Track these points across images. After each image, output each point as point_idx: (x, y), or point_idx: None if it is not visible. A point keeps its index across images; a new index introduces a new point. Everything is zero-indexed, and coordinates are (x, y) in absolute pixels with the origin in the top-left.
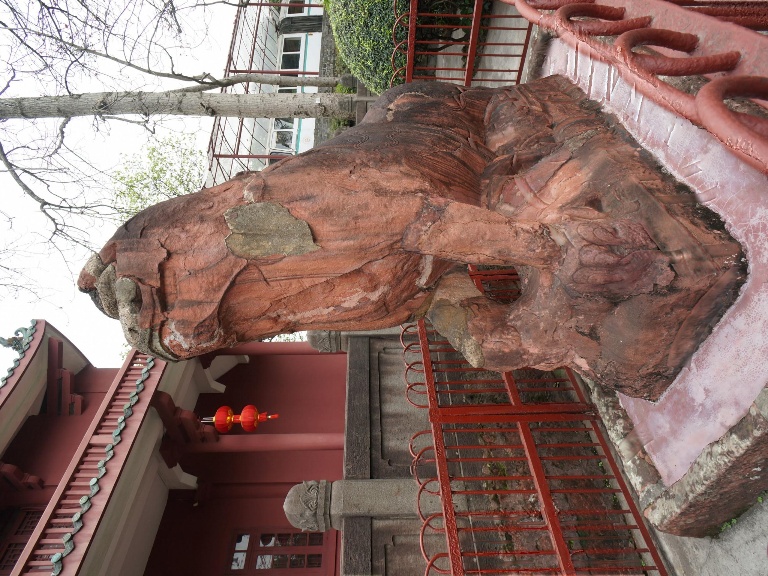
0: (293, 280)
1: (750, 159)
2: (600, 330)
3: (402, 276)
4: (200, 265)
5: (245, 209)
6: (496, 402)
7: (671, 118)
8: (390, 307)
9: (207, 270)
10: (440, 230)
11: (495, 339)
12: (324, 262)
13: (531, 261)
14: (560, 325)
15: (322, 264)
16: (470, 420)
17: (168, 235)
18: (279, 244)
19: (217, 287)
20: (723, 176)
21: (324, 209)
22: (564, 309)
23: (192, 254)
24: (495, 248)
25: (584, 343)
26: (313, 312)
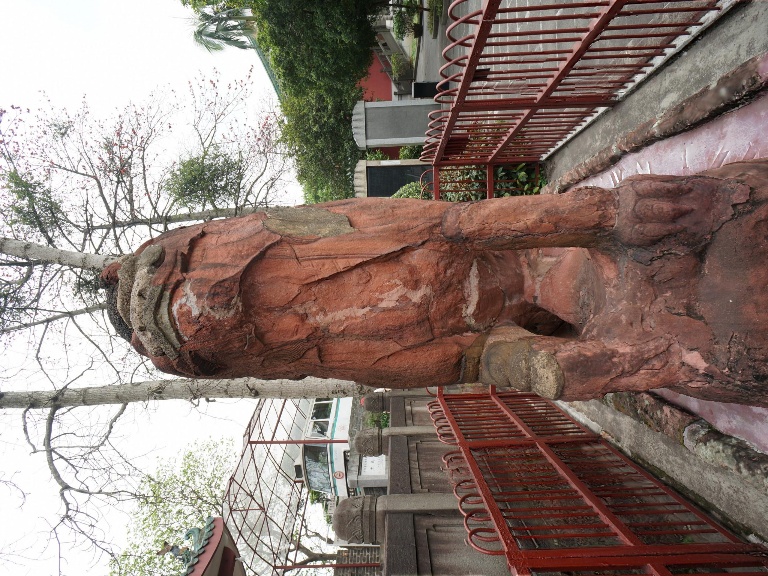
0: (326, 260)
1: (766, 101)
2: (699, 308)
3: (446, 284)
4: (232, 240)
5: (286, 210)
6: (605, 544)
7: (680, 149)
8: (435, 330)
9: (239, 241)
10: (479, 207)
11: (570, 346)
12: (360, 243)
13: (583, 211)
14: (646, 311)
15: (358, 244)
16: (572, 562)
17: (207, 225)
18: (315, 228)
19: (245, 255)
20: (751, 134)
21: (362, 206)
22: (643, 287)
23: (227, 234)
24: (541, 210)
25: (685, 325)
26: (346, 312)
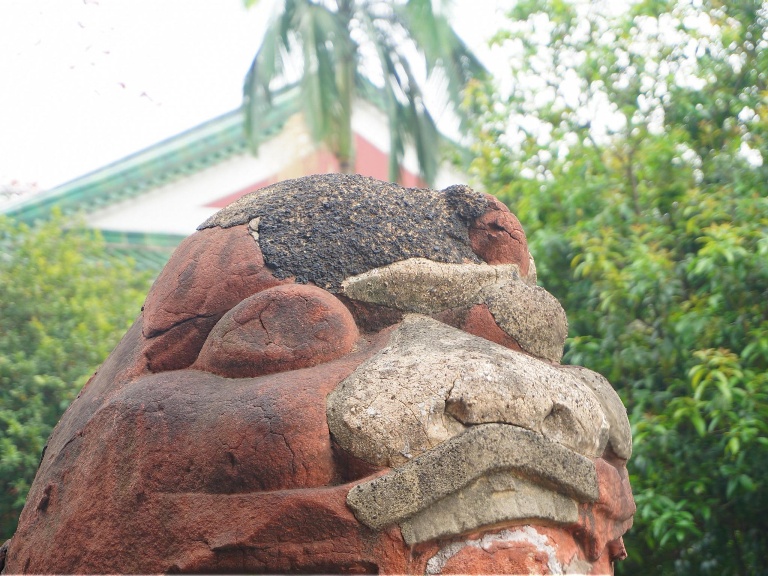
0: None
1: None
2: None
3: None
4: None
5: None
6: None
7: None
8: None
9: None
10: None
11: None
12: None
13: None
14: None
15: None
16: None
17: None
18: None
19: None
20: None
21: None
22: None
23: None
24: None
25: None
26: None
